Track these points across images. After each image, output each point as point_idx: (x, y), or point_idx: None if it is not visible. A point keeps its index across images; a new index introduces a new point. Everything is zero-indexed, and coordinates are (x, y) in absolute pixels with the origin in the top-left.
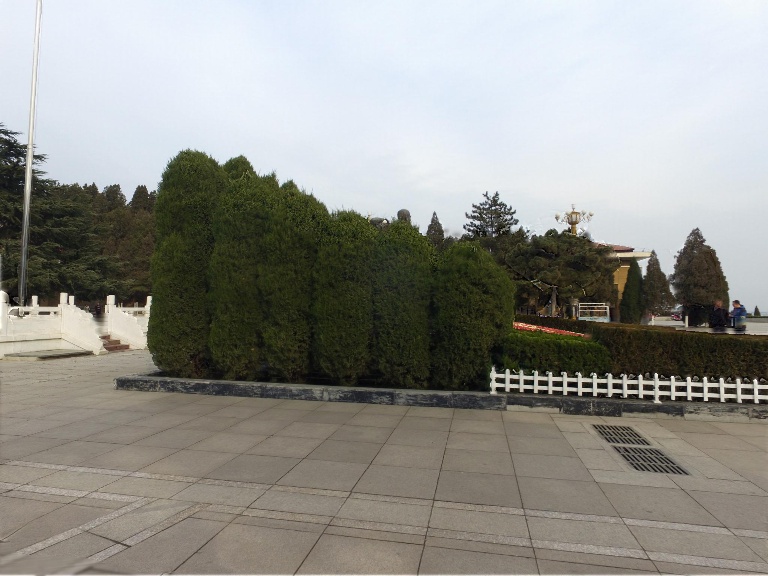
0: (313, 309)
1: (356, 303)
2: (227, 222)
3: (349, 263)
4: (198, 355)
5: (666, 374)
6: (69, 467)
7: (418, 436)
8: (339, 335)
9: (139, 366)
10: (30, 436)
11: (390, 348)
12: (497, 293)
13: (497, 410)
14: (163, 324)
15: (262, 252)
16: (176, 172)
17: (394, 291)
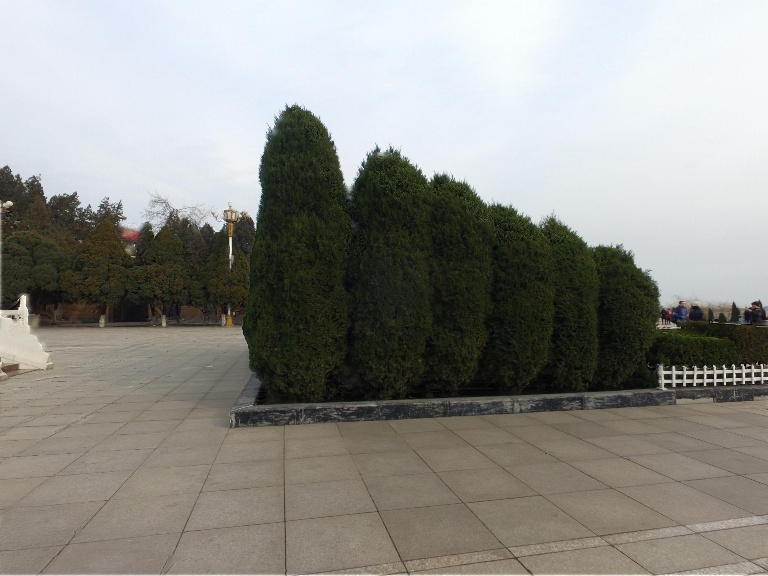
0: (500, 312)
1: (547, 305)
2: (395, 205)
3: (541, 262)
4: (331, 371)
5: (767, 362)
6: (604, 539)
7: (718, 437)
8: (533, 340)
9: (134, 393)
10: (386, 510)
11: (573, 351)
12: (656, 295)
13: (670, 405)
14: (300, 333)
15: (435, 245)
16: (302, 133)
17: (575, 292)
